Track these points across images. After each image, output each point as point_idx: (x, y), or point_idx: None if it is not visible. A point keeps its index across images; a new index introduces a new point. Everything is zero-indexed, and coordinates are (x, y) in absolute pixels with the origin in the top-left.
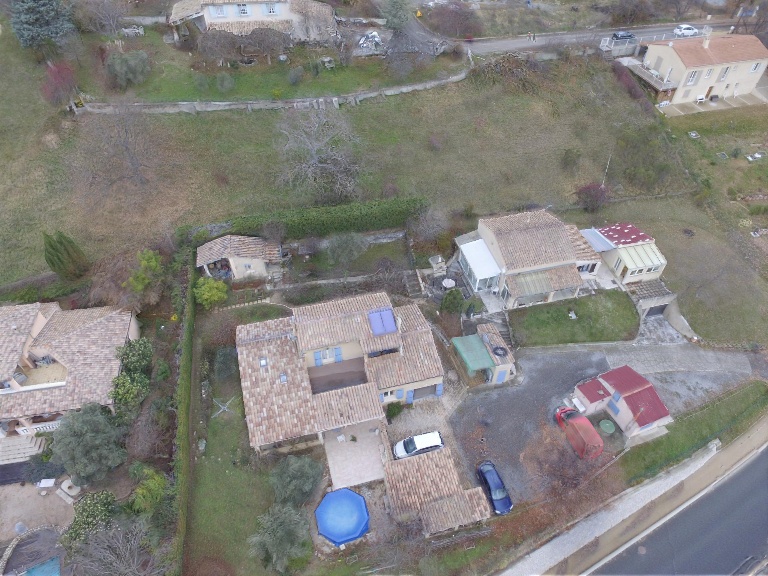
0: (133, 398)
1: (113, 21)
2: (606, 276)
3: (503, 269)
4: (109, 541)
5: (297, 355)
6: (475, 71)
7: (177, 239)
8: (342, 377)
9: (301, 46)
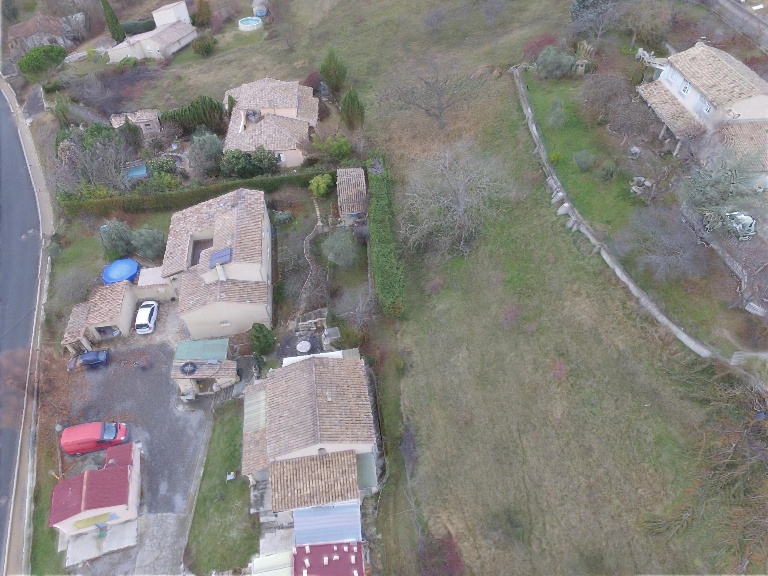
0: None
1: (603, 28)
2: (285, 549)
3: None
4: None
5: None
6: (725, 369)
7: None
8: None
9: (683, 162)
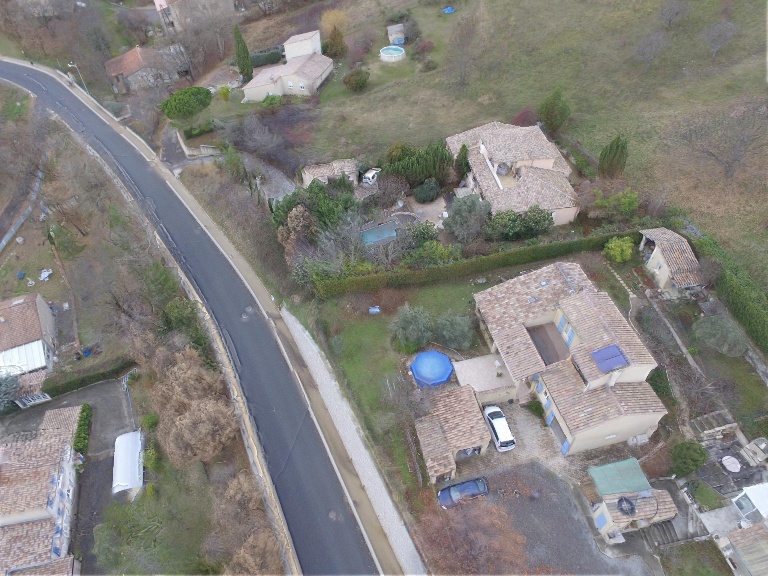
0: (500, 224)
1: None
2: None
3: (767, 512)
4: (408, 242)
5: (557, 304)
6: None
7: (665, 211)
8: (550, 349)
9: None
